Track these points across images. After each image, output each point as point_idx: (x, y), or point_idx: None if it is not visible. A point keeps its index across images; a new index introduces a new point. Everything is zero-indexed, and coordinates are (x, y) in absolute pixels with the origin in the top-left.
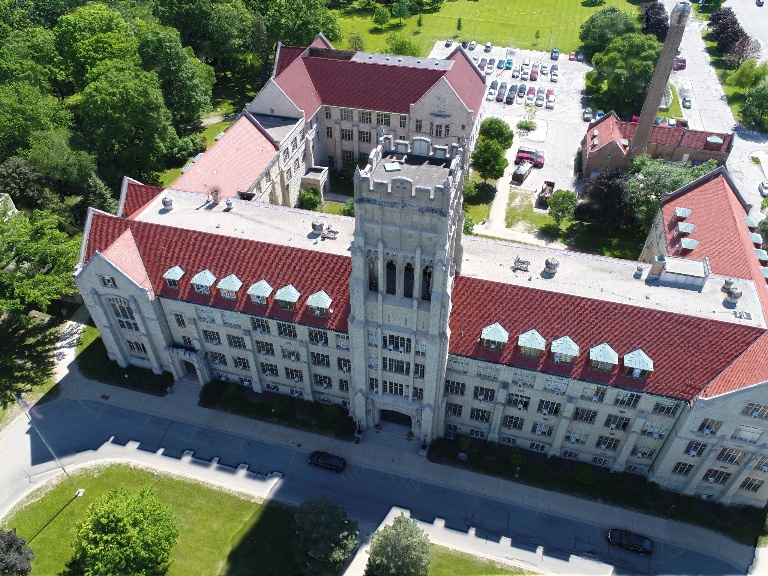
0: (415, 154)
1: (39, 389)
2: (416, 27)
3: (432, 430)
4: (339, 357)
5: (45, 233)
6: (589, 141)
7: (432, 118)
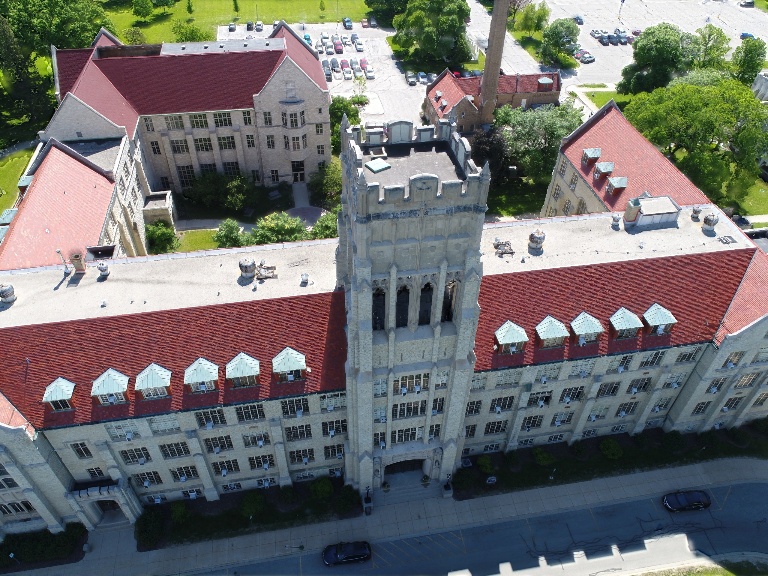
0: (393, 143)
1: None
2: (186, 15)
3: None
4: (324, 422)
5: None
6: (435, 103)
7: (283, 107)
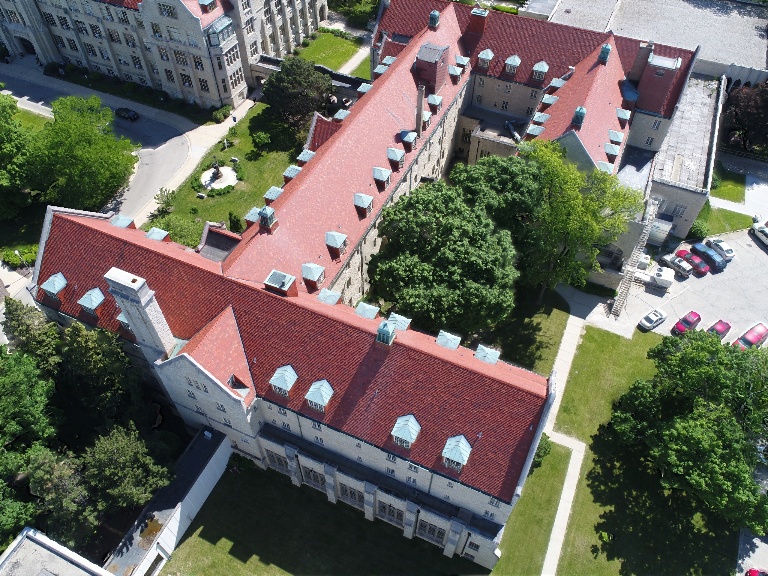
0: None
1: None
2: None
3: (44, 53)
4: None
5: None
6: None
7: None
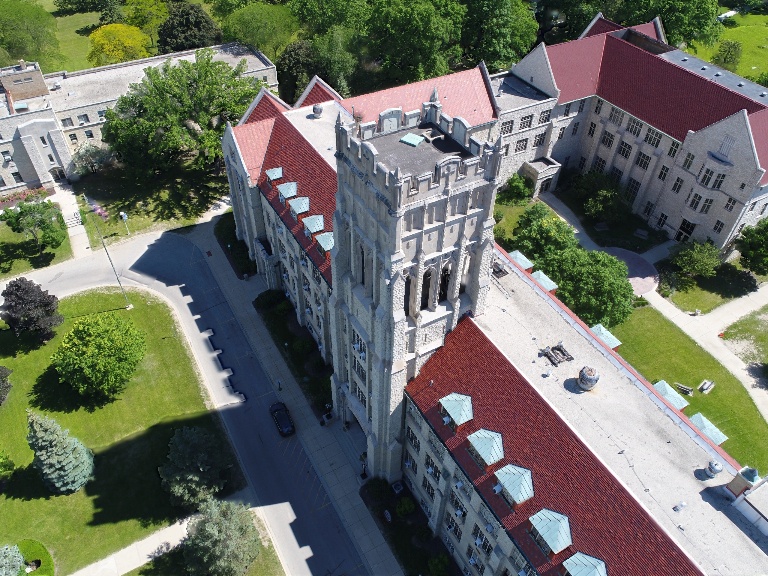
0: (454, 138)
1: (183, 221)
2: None
3: (378, 465)
4: None
5: (250, 101)
6: None
7: (707, 158)
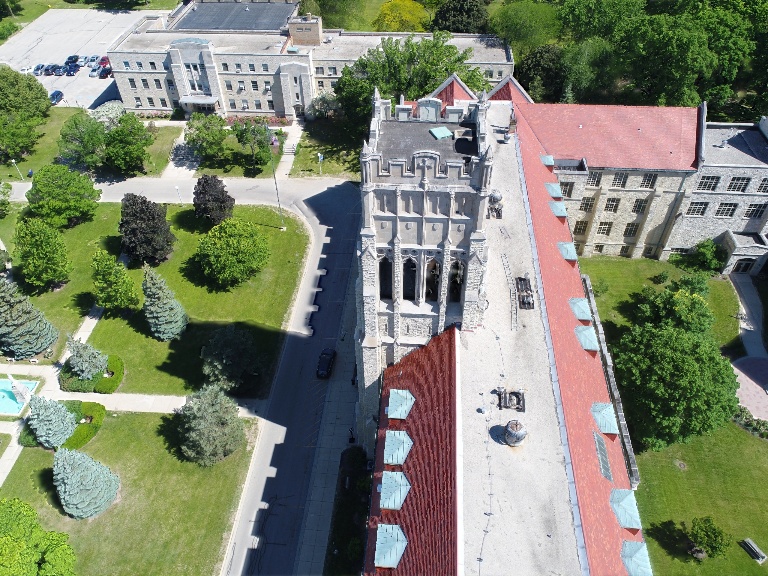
0: None
1: None
2: None
3: (363, 436)
4: None
5: None
6: None
7: None
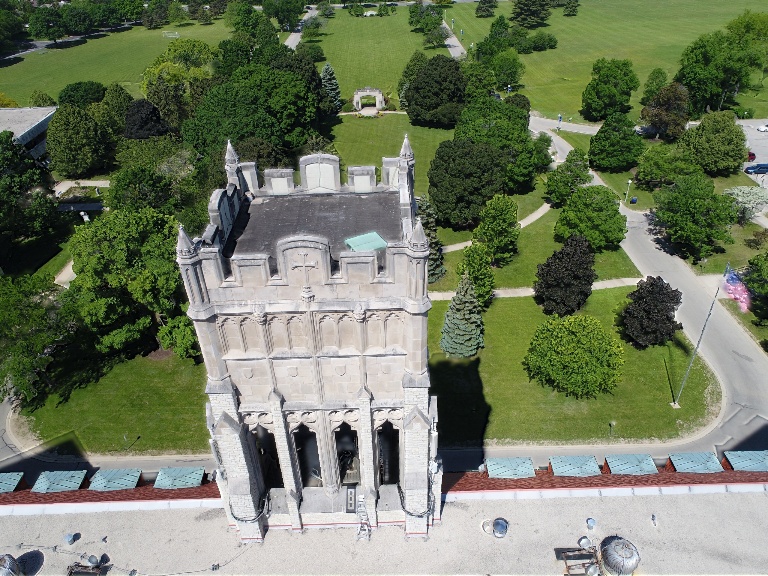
0: None
1: None
2: None
3: None
4: None
5: None
6: None
7: None
